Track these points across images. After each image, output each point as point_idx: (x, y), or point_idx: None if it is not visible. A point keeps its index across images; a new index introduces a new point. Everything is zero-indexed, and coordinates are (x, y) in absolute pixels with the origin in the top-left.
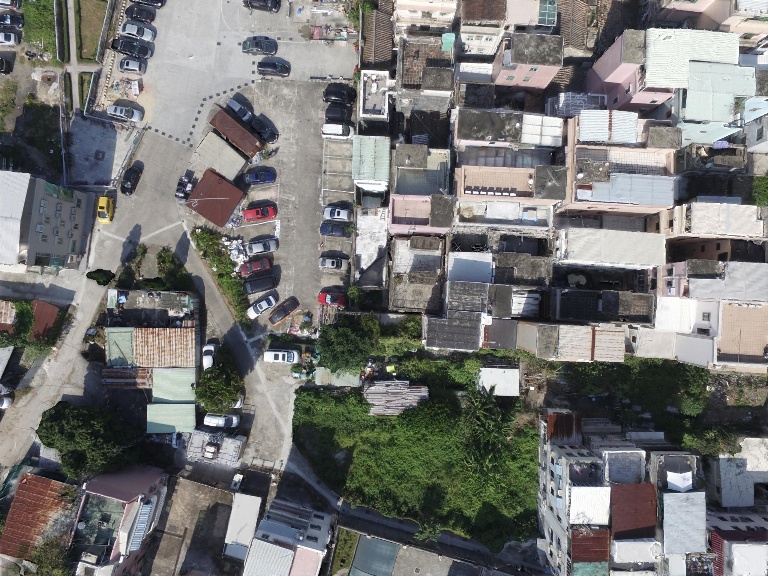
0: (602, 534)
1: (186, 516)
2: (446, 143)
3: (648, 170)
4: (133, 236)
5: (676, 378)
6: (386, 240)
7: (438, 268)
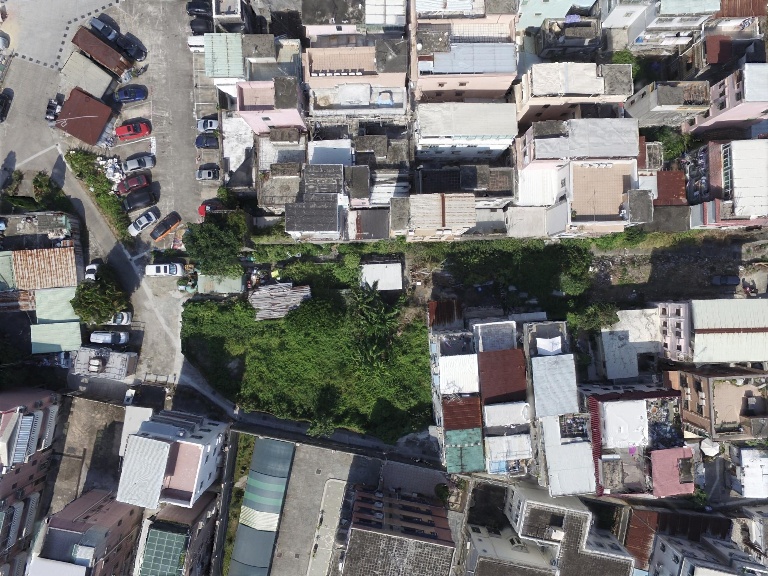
0: (473, 401)
1: (84, 437)
2: (309, 43)
3: (493, 41)
4: (8, 163)
5: (557, 260)
6: (253, 141)
7: (303, 162)
